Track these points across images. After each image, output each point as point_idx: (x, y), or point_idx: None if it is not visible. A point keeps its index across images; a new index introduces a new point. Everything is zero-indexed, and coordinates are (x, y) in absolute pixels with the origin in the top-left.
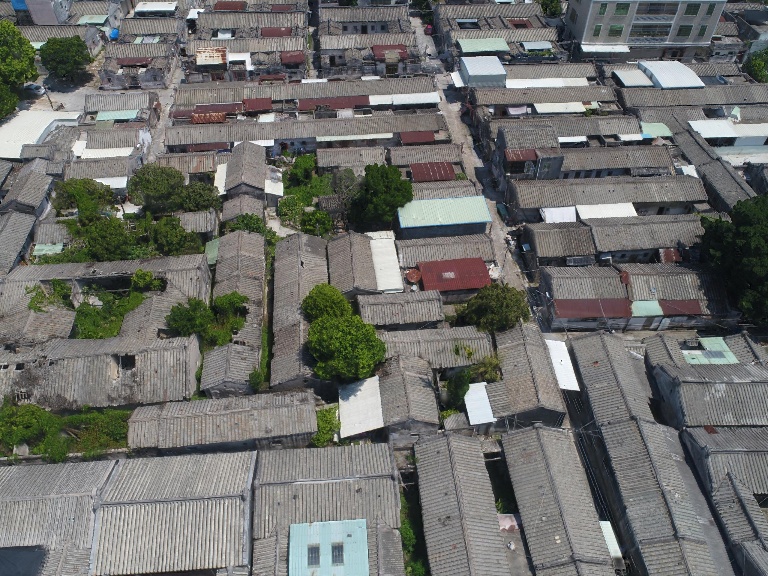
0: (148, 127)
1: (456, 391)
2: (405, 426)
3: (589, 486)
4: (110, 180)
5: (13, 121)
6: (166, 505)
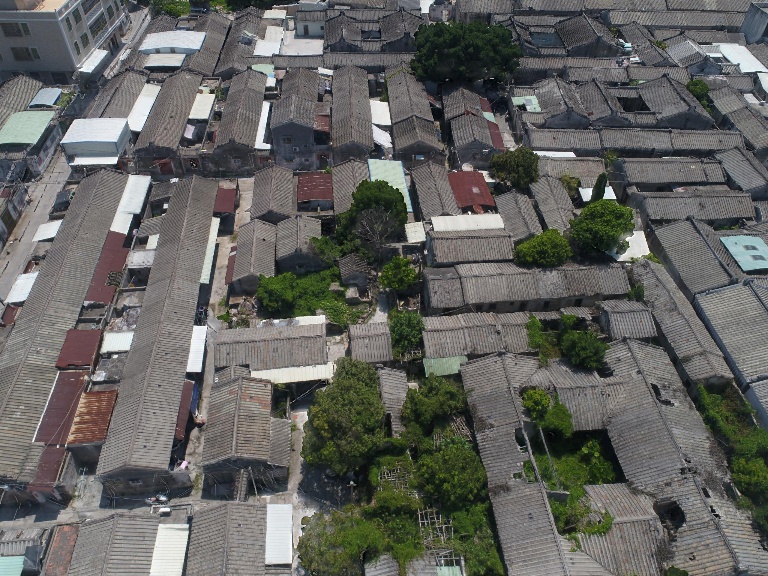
0: None
1: None
2: None
3: None
4: (273, 533)
5: None
6: None
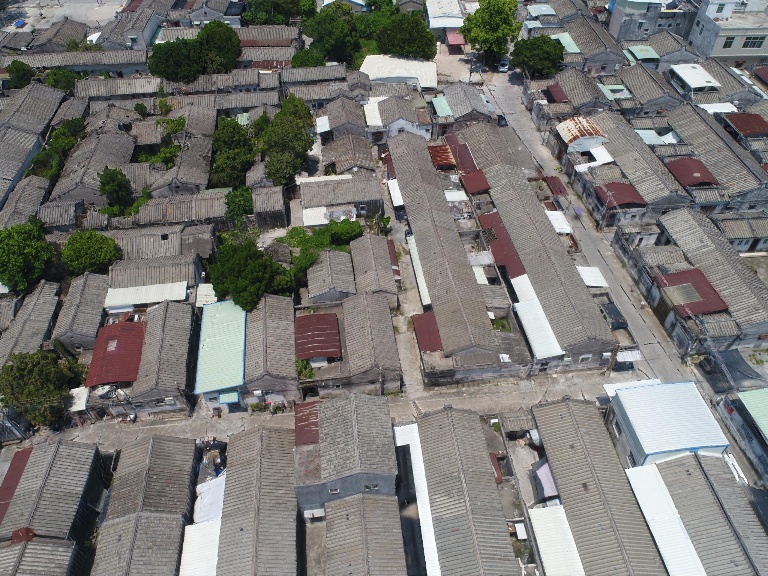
0: (432, 128)
1: None
2: None
3: None
4: (326, 123)
5: (410, 62)
6: None
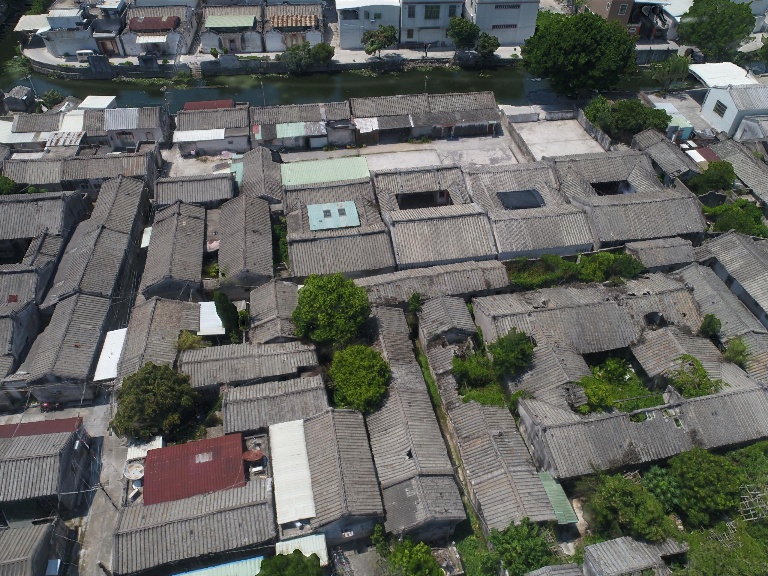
0: None
1: None
2: None
3: None
4: None
5: None
6: None
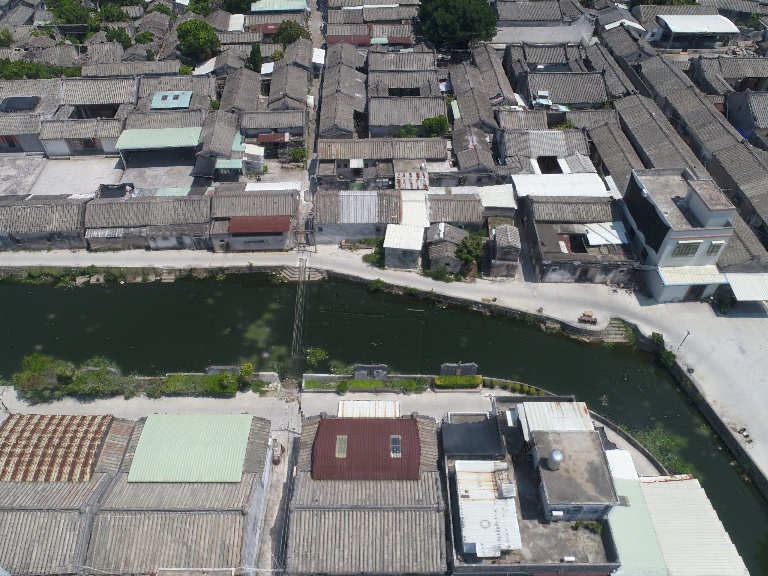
0: None
1: (254, 58)
2: (225, 71)
3: (318, 100)
4: None
5: None
6: (97, 82)
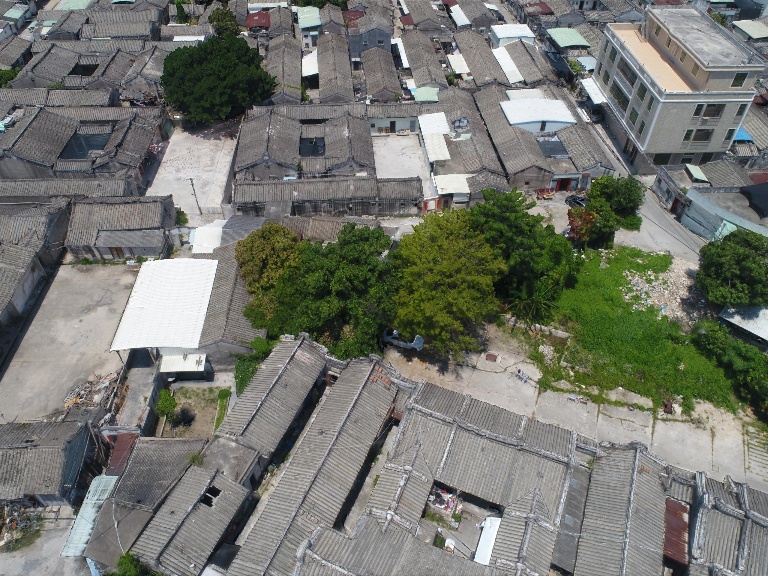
0: None
1: None
2: None
3: None
4: None
5: None
6: None
